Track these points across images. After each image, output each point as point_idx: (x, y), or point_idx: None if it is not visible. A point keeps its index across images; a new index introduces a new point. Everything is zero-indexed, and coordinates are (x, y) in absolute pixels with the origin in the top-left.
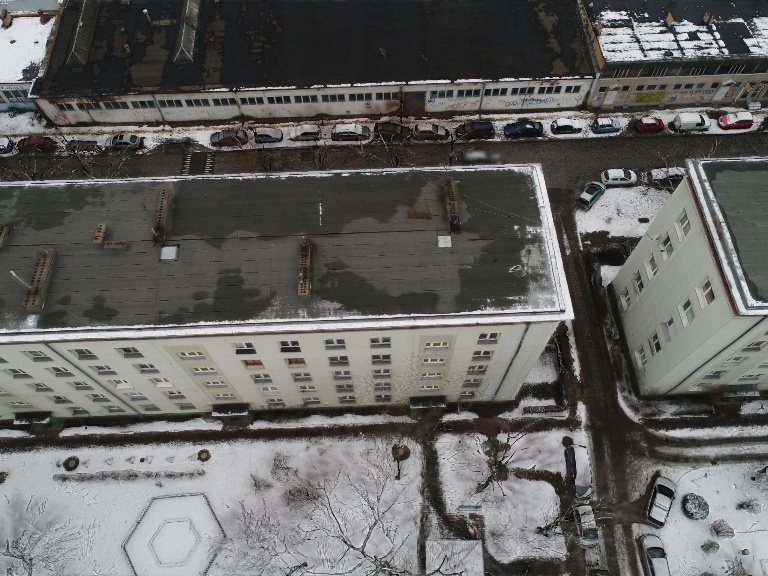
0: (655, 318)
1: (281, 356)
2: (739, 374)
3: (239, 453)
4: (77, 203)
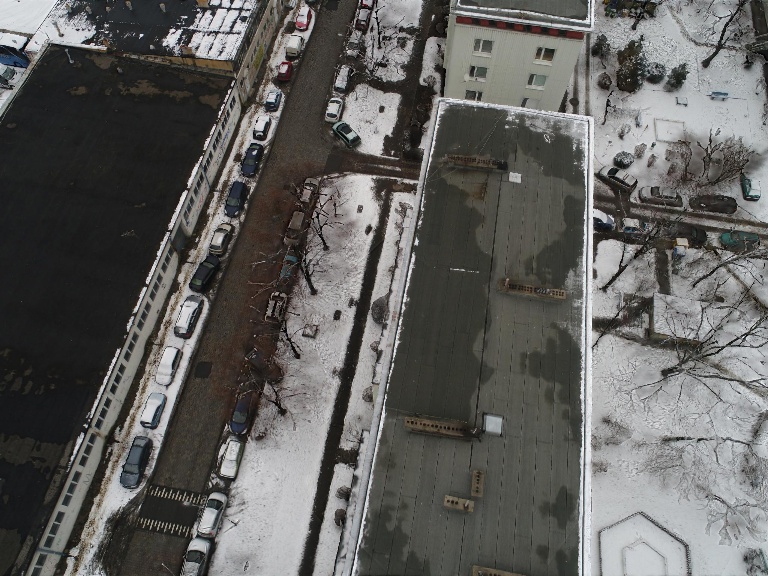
0: None
1: None
2: None
3: None
4: (395, 542)
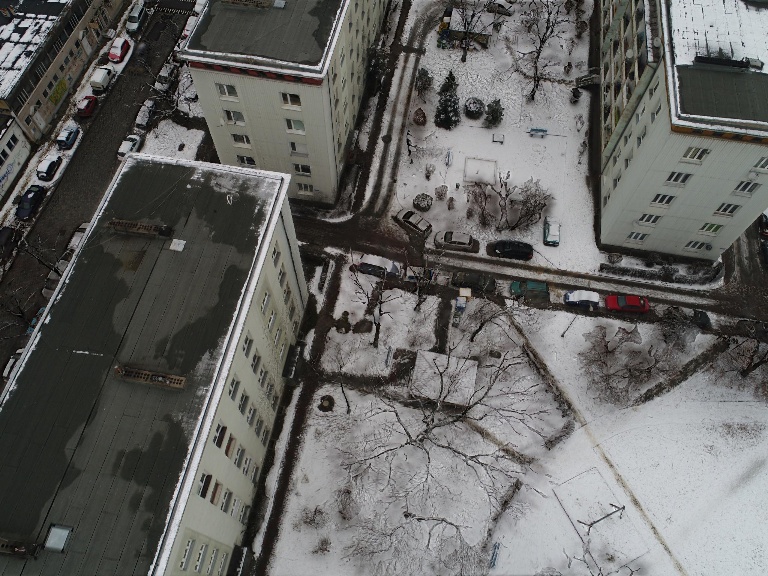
0: (284, 159)
1: (222, 453)
2: (343, 130)
3: (281, 572)
4: None
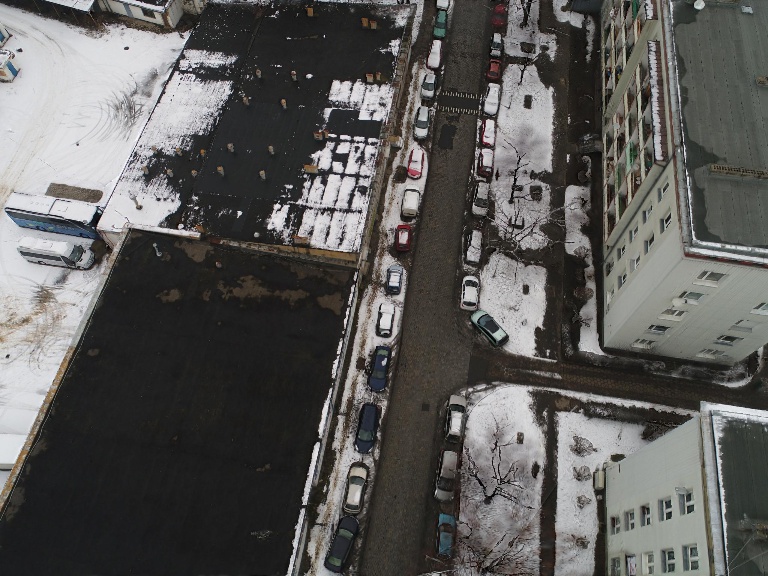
0: (715, 331)
1: None
2: None
3: None
4: None
